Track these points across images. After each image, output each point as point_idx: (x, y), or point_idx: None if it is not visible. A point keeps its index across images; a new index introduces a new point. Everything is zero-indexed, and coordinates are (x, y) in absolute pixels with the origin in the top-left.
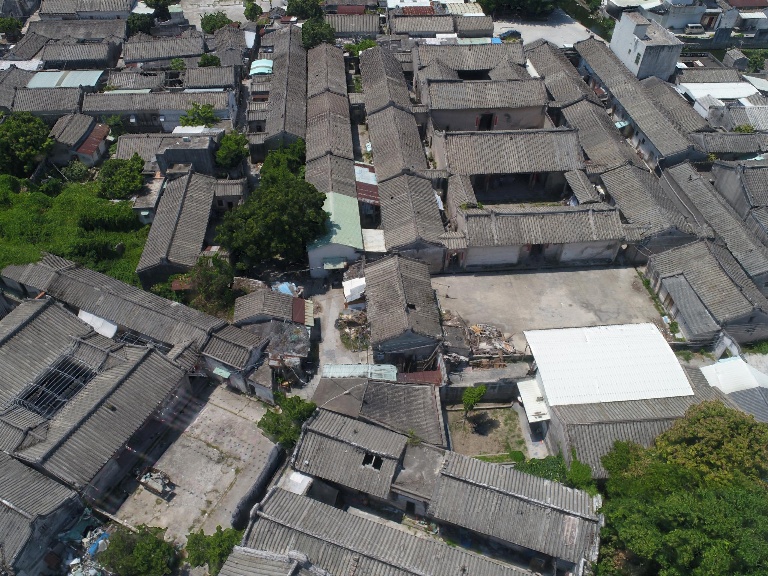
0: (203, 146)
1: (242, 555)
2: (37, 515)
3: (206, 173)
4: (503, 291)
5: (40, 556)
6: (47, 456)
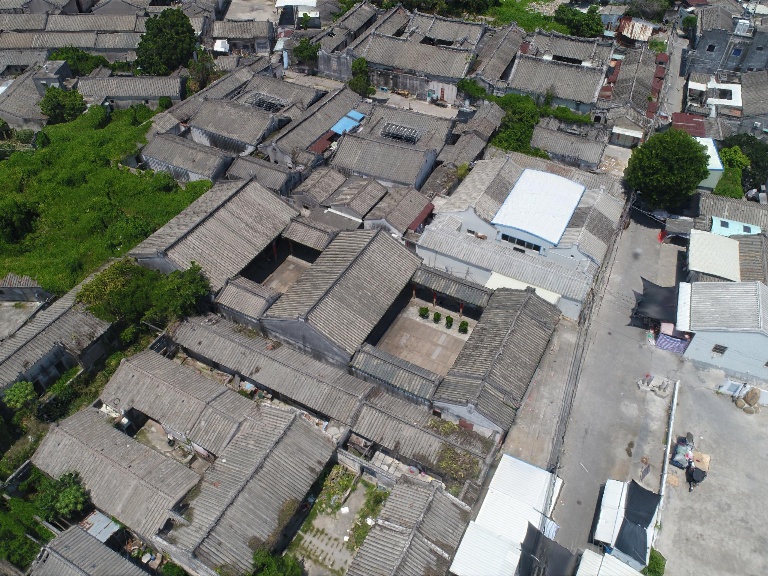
0: (60, 63)
1: (365, 55)
2: (345, 83)
3: None
4: None
5: None
6: None
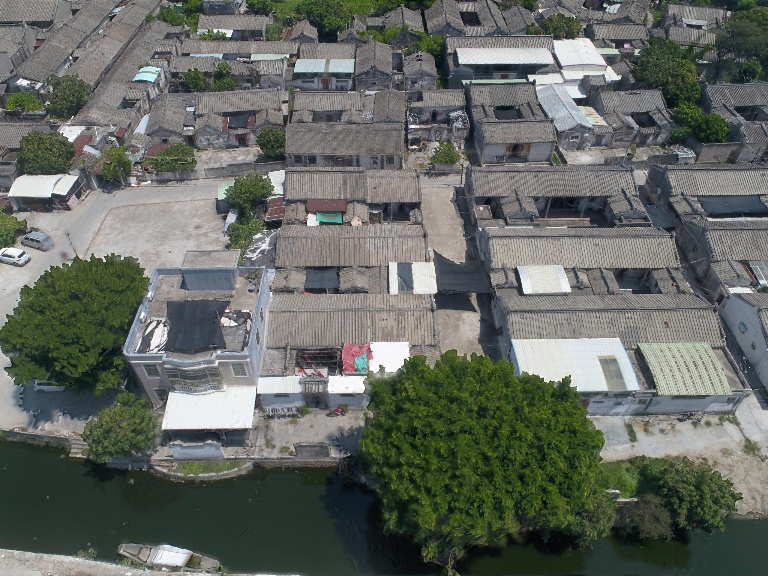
0: None
1: None
2: None
3: None
4: None
5: None
6: None
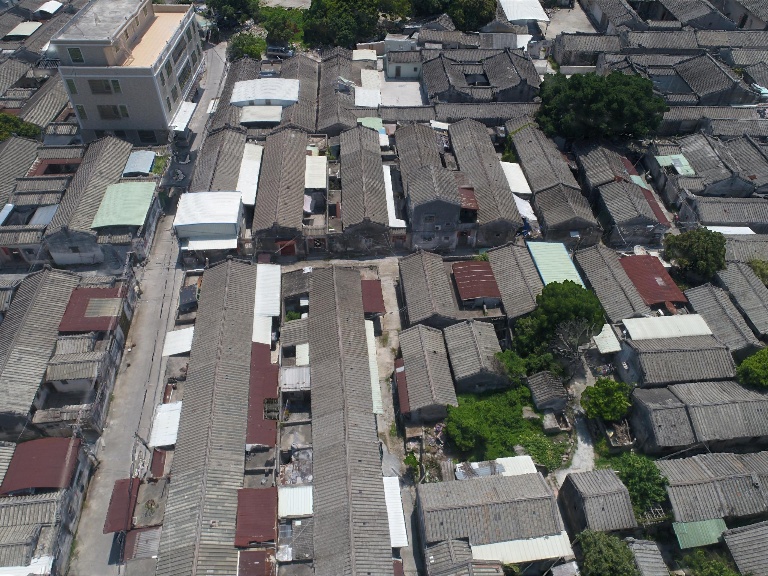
0: None
1: None
2: None
3: None
4: (578, 21)
5: None
6: None
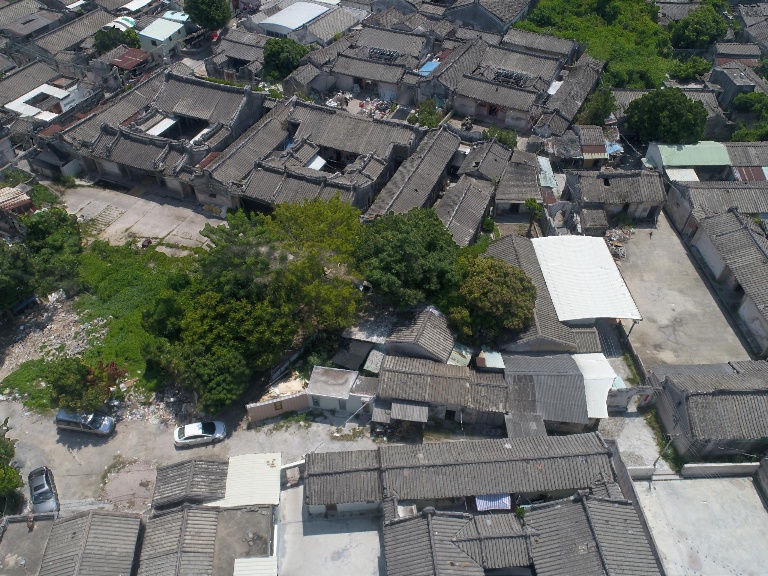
0: (739, 83)
1: None
2: (437, 76)
3: (725, 104)
4: (674, 268)
5: (427, 94)
6: (467, 77)
